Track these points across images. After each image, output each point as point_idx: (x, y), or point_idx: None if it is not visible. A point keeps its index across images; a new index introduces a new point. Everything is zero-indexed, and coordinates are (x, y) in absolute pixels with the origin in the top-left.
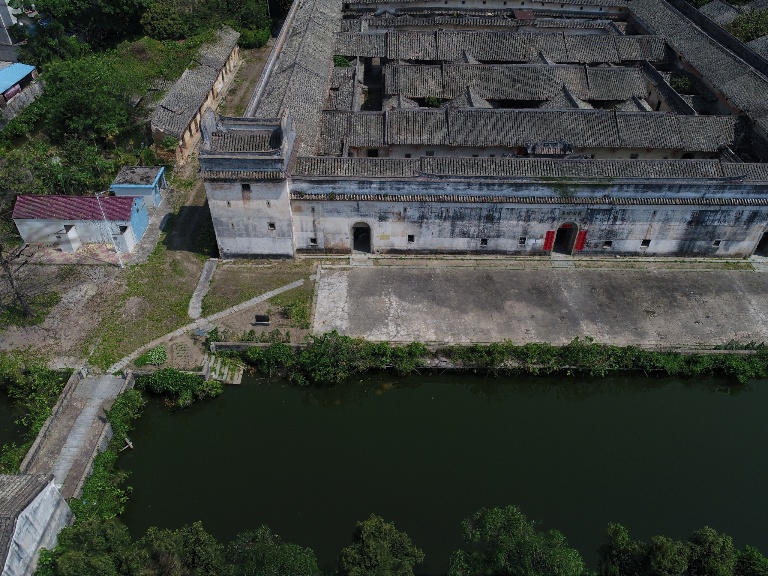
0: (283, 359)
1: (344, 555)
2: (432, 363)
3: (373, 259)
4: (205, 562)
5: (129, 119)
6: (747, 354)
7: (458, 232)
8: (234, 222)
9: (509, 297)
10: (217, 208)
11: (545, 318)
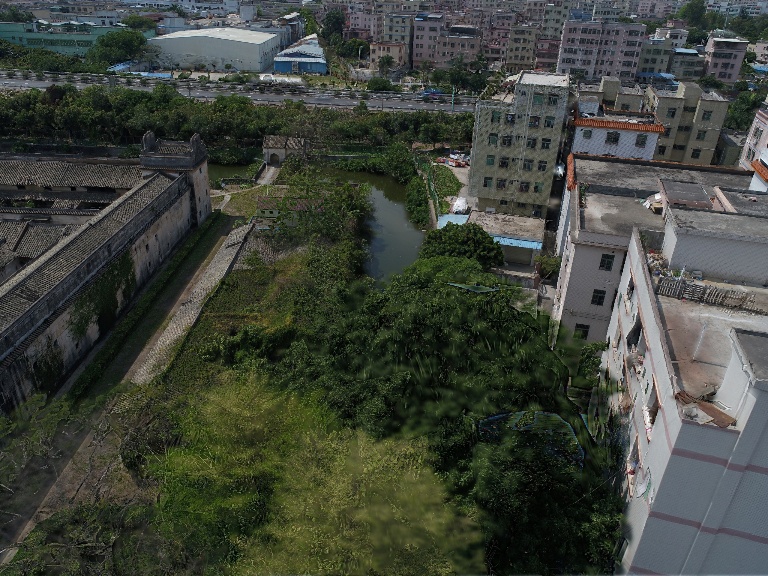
0: None
1: (183, 115)
2: None
3: None
4: None
5: None
6: None
7: None
8: None
9: None
10: None
11: None
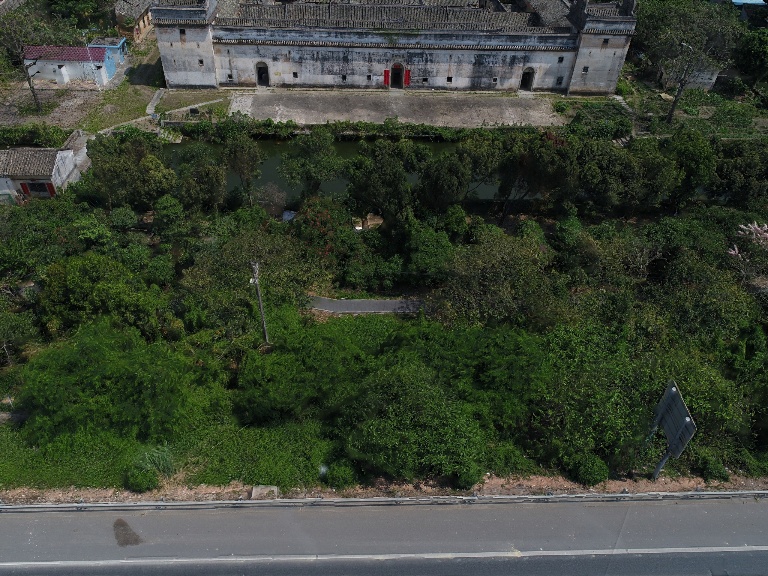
0: (207, 128)
1: None
2: (300, 132)
3: (271, 90)
4: (158, 149)
5: (98, 8)
6: (493, 129)
7: (326, 70)
8: (175, 59)
9: (356, 107)
10: (164, 48)
11: (376, 115)
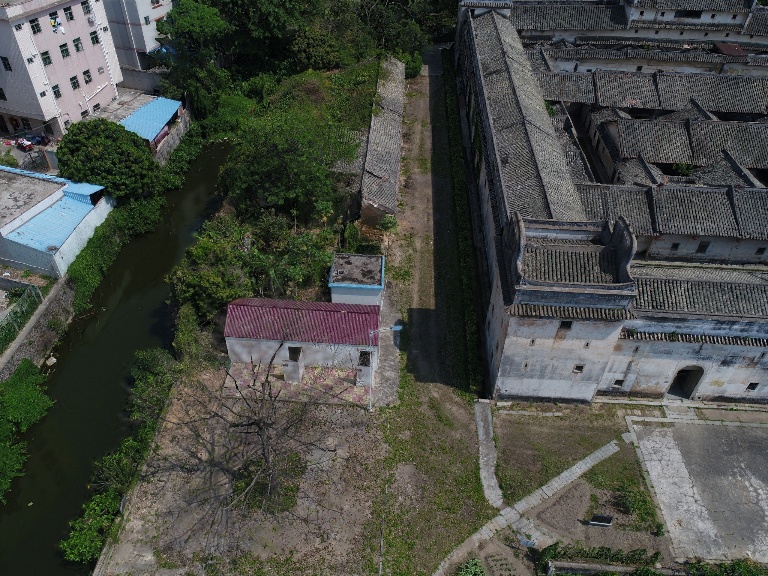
0: None
1: None
2: None
3: (694, 409)
4: None
5: None
6: None
7: None
8: (530, 362)
9: None
10: (514, 346)
11: None
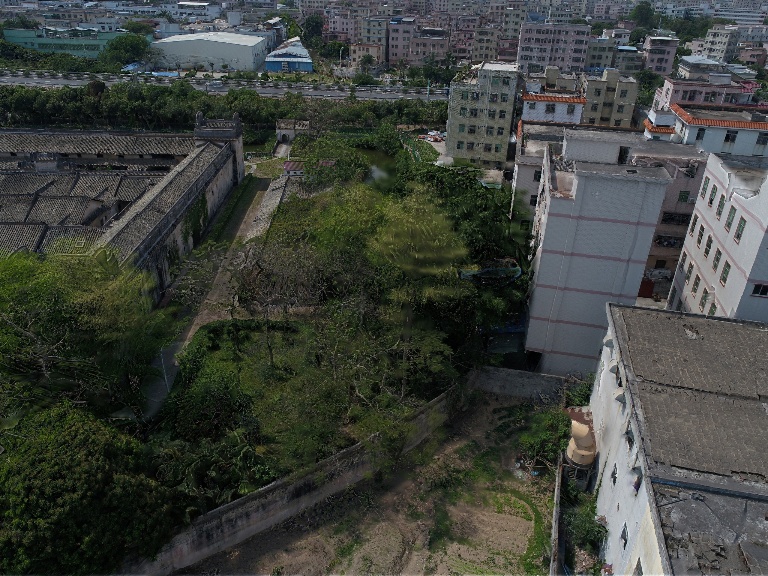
0: None
1: None
2: None
3: None
4: None
5: None
6: None
7: None
8: None
9: None
10: None
11: None
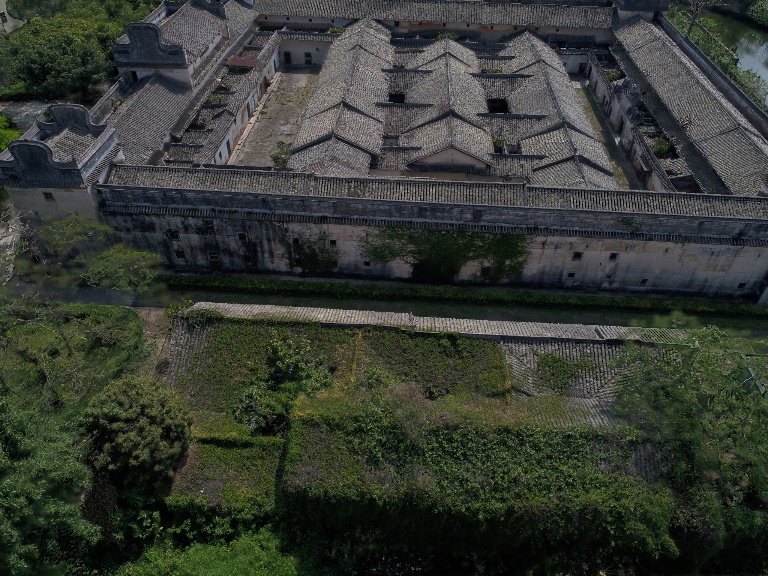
0: None
1: None
2: None
3: None
4: None
5: None
6: None
7: None
8: None
9: None
10: None
11: None
